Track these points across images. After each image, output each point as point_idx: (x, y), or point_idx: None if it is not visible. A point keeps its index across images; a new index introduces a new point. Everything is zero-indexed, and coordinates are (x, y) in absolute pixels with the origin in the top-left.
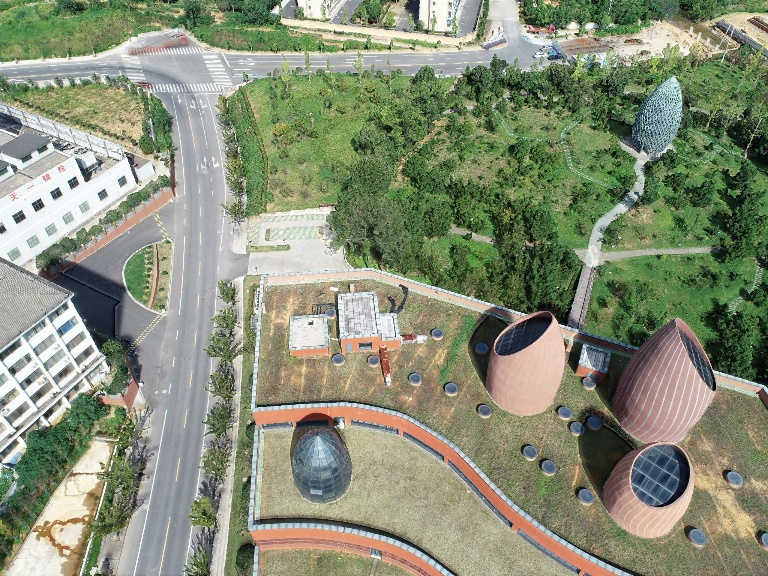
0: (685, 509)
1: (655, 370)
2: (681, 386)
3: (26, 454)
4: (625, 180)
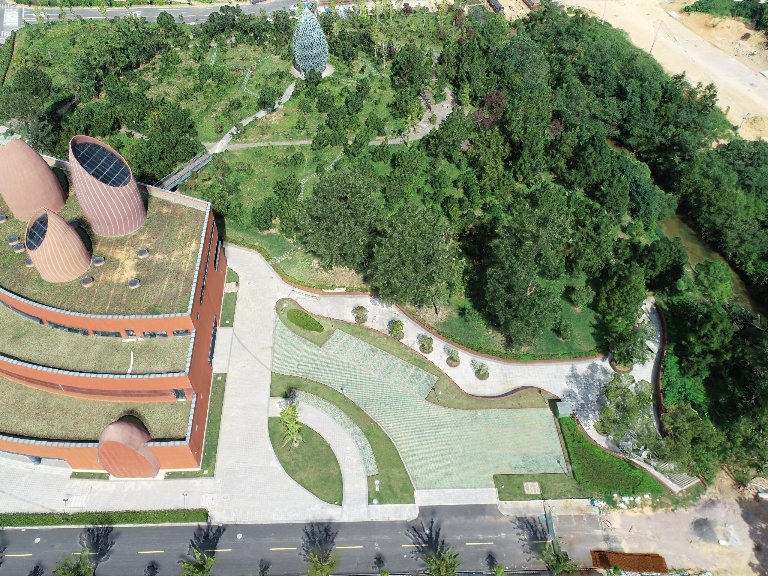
0: (61, 255)
1: None
2: (79, 179)
3: None
4: None
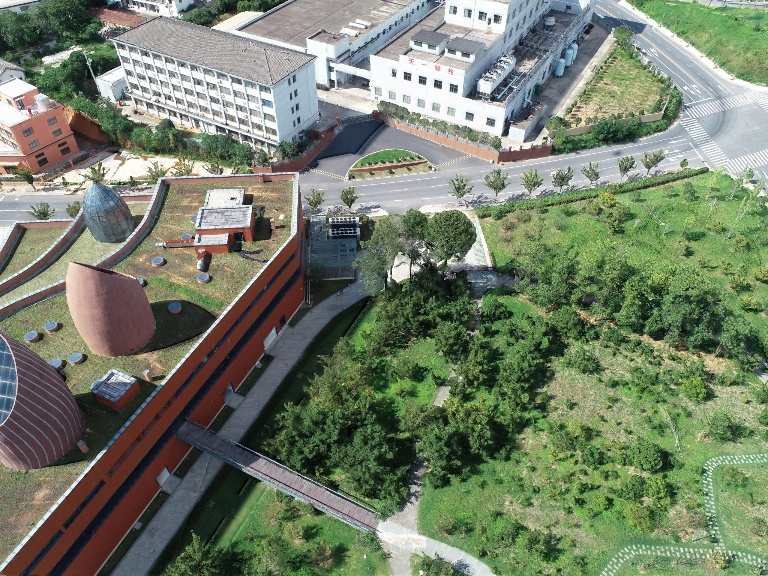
0: None
1: None
2: None
3: (214, 135)
4: None
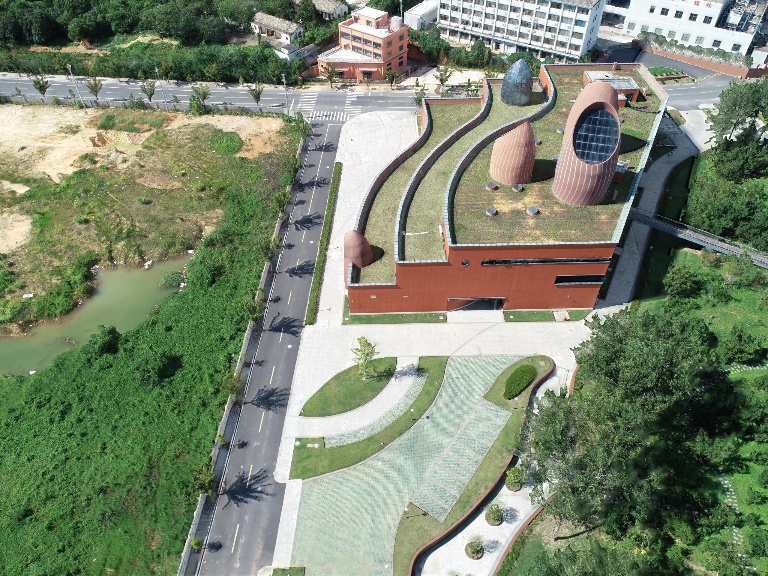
0: None
1: None
2: None
3: None
4: None
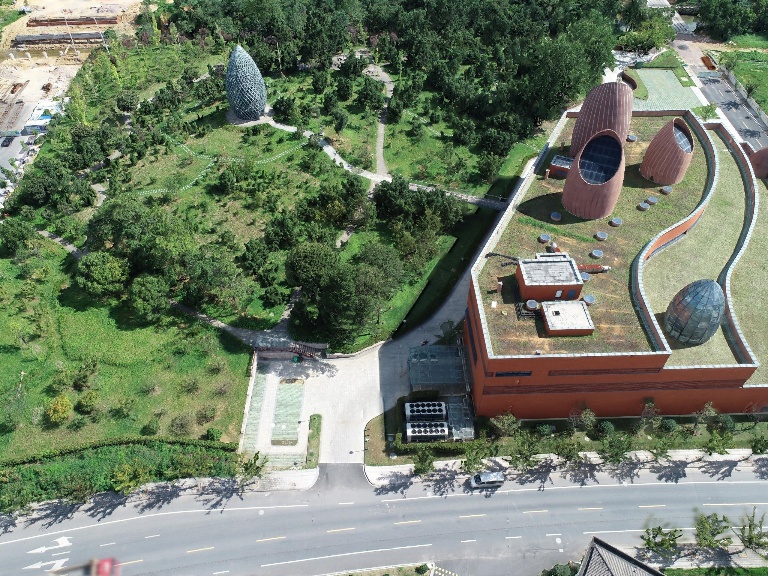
0: None
1: (623, 112)
2: None
3: None
4: (298, 135)
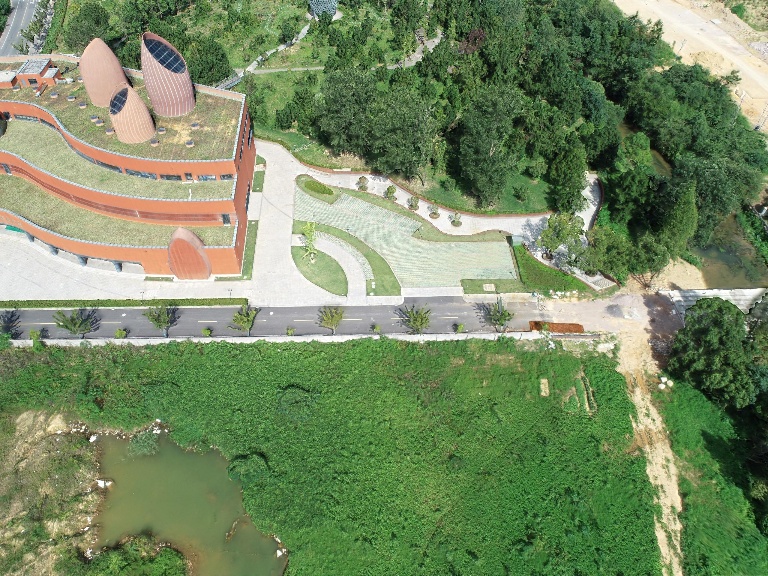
0: (136, 119)
1: None
2: (148, 65)
3: None
4: None
